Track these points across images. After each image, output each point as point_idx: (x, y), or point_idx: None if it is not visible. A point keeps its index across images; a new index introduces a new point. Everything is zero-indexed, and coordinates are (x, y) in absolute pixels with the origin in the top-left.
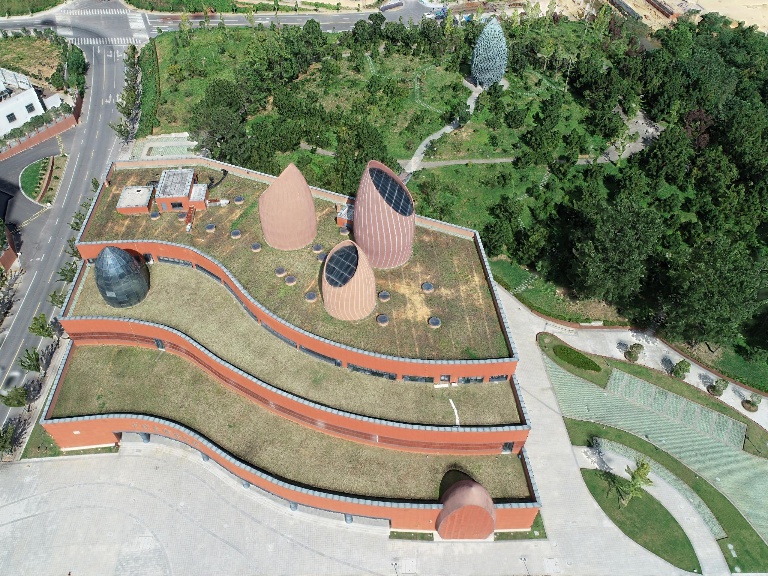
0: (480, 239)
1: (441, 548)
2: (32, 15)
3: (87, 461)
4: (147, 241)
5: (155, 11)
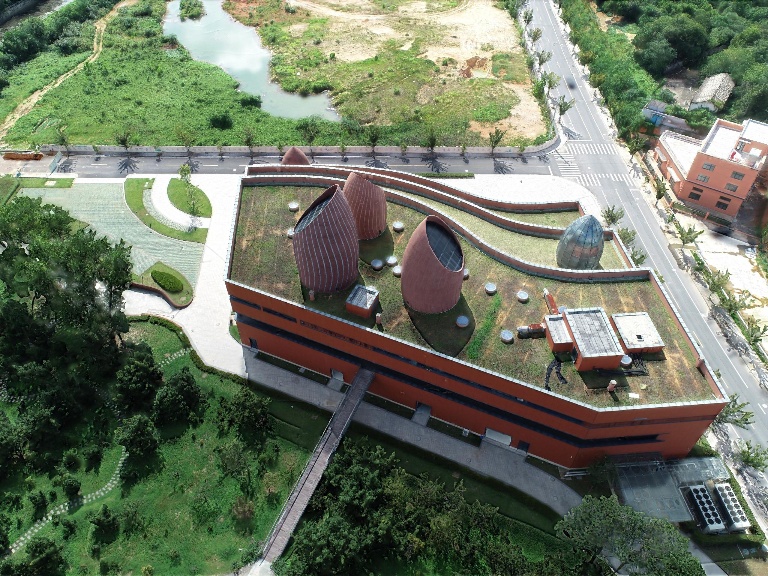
0: (225, 270)
1: None
2: None
3: None
4: (578, 270)
5: None
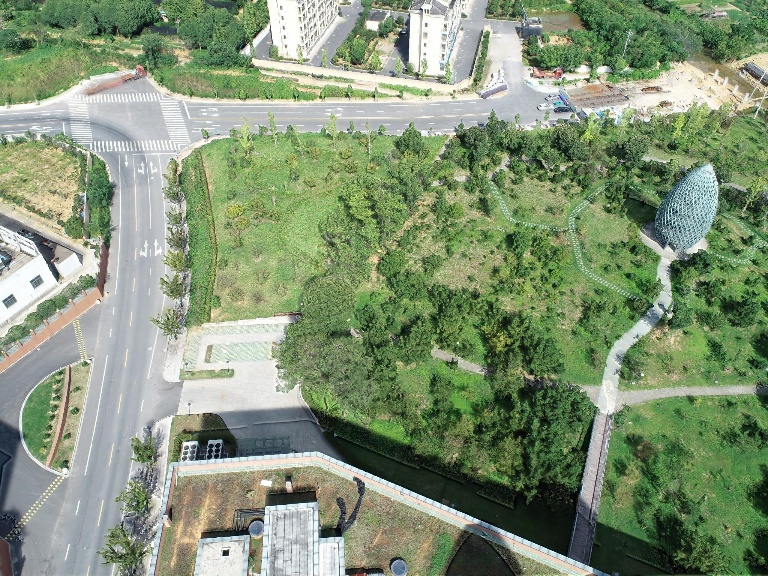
0: None
1: None
2: (39, 103)
3: None
4: None
5: (195, 97)
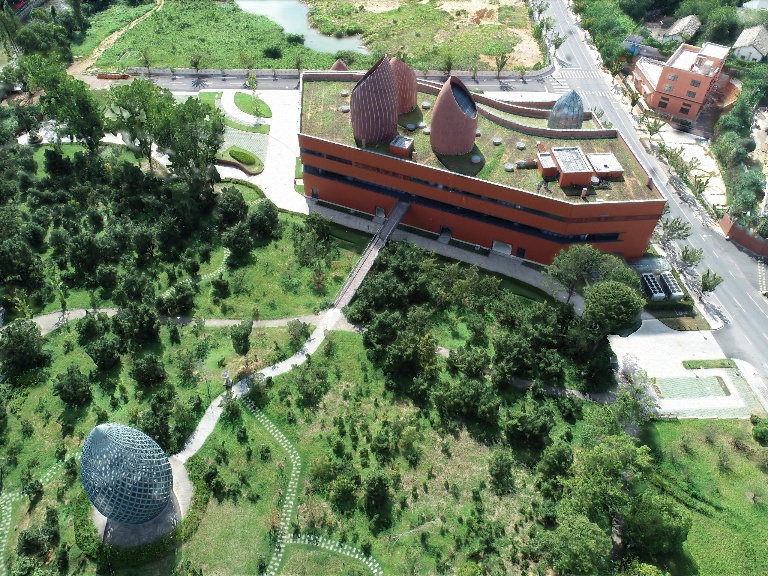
0: (298, 128)
1: None
2: None
3: None
4: None
5: None
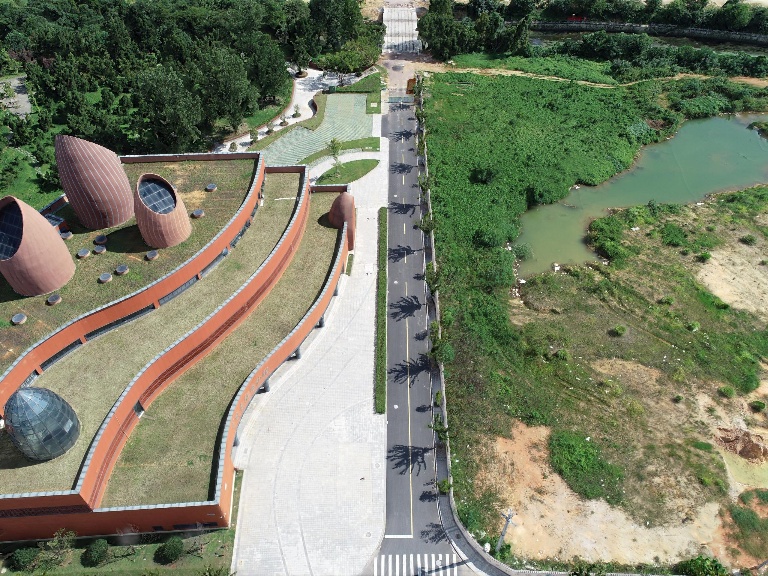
0: None
1: (358, 252)
2: None
3: (247, 499)
4: None
5: None
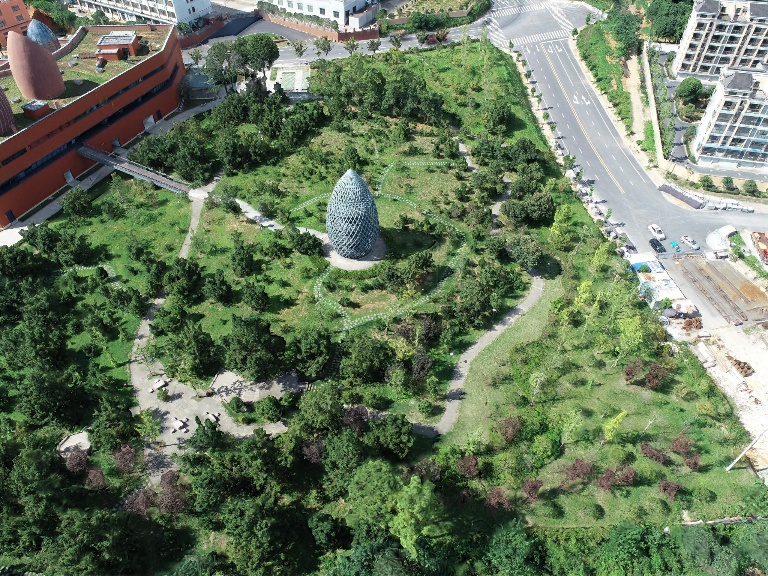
0: None
1: None
2: None
3: None
4: None
5: (576, 41)
